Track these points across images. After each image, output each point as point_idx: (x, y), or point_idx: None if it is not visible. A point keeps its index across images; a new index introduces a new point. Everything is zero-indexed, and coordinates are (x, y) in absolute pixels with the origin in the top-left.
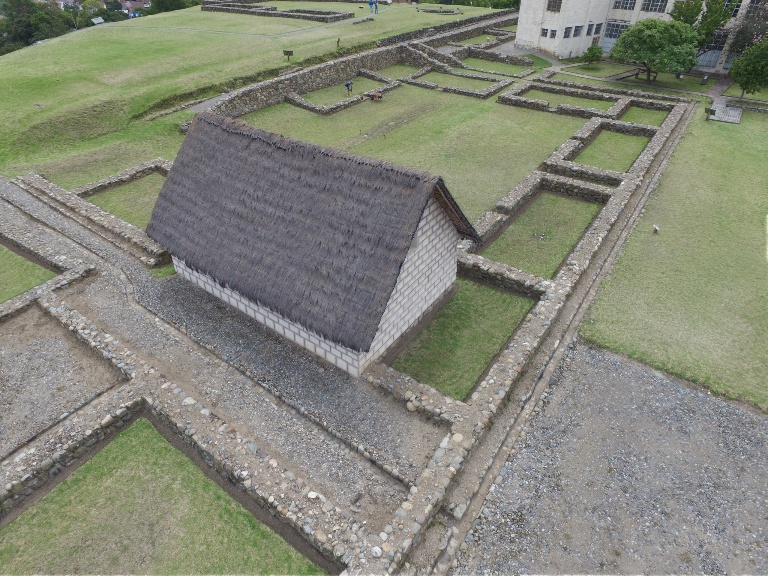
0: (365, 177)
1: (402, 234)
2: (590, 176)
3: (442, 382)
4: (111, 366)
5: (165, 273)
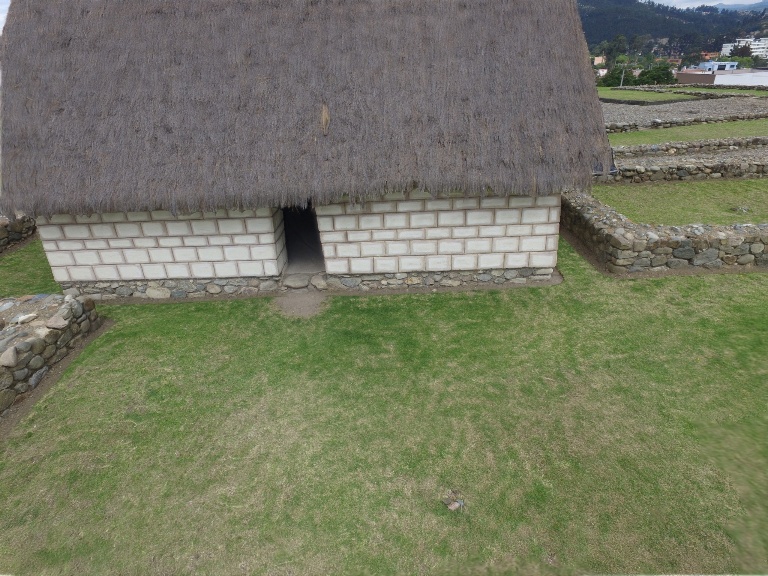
0: None
1: None
2: None
3: None
4: None
5: None
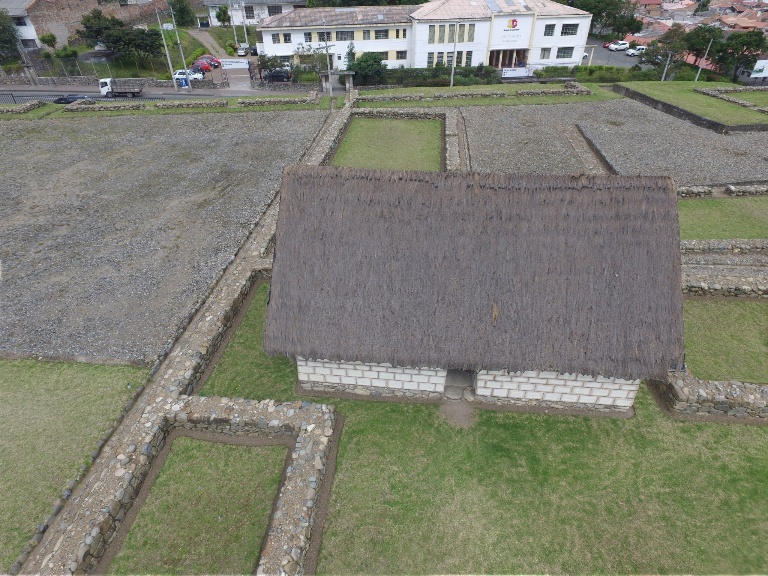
0: None
1: None
2: None
3: None
4: None
5: None
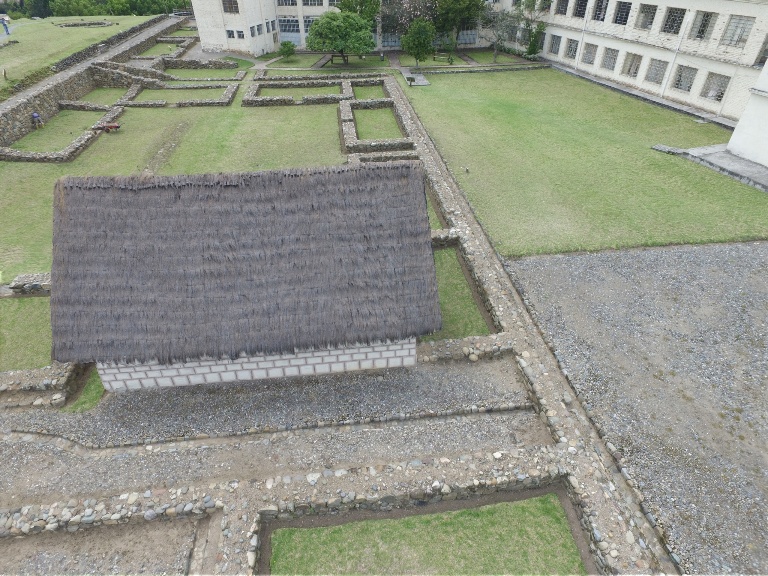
0: (353, 183)
1: (420, 218)
2: (388, 147)
3: (465, 332)
4: (167, 521)
5: (92, 400)
